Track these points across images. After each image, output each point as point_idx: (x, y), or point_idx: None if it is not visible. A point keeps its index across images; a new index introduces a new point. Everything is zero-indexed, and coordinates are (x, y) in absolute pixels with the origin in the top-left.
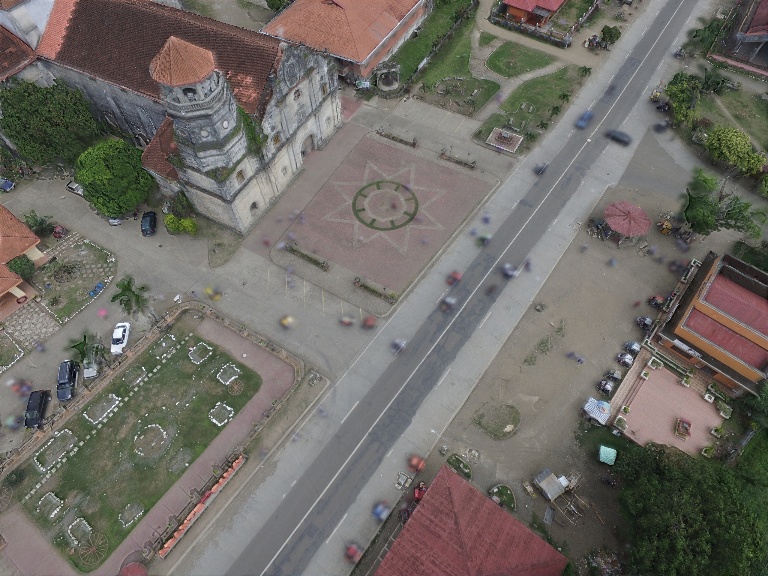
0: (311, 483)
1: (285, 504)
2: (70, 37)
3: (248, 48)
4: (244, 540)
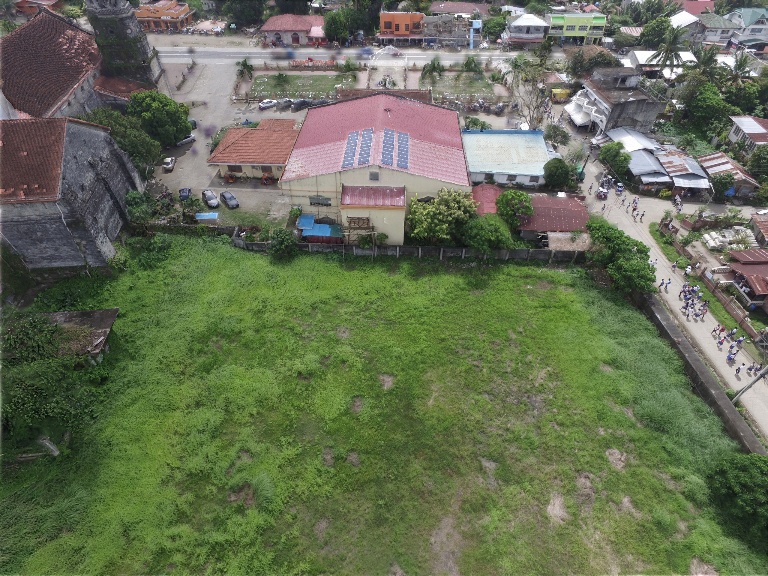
0: None
1: None
2: (11, 103)
3: (41, 22)
4: None
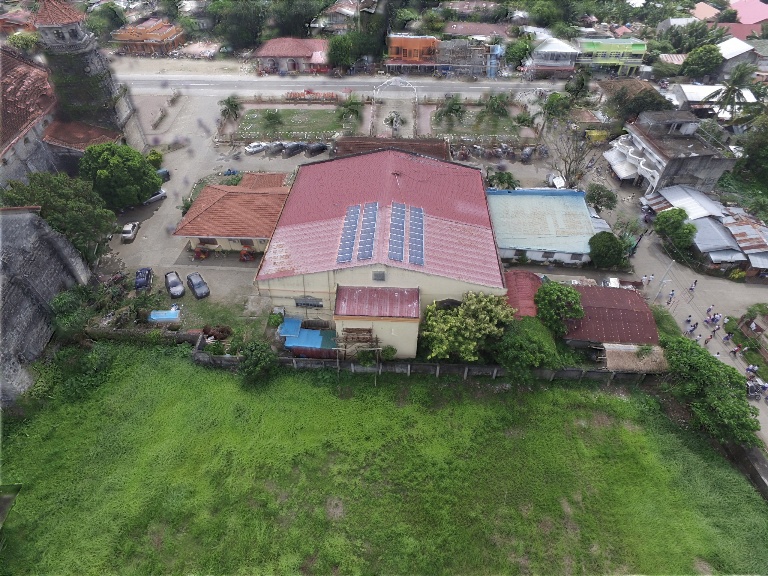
0: (281, 88)
1: (294, 89)
2: None
3: None
4: (314, 91)
